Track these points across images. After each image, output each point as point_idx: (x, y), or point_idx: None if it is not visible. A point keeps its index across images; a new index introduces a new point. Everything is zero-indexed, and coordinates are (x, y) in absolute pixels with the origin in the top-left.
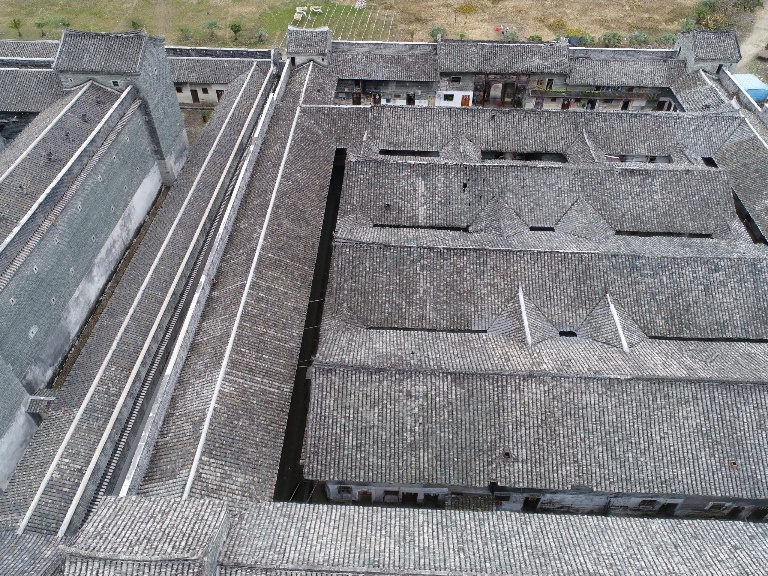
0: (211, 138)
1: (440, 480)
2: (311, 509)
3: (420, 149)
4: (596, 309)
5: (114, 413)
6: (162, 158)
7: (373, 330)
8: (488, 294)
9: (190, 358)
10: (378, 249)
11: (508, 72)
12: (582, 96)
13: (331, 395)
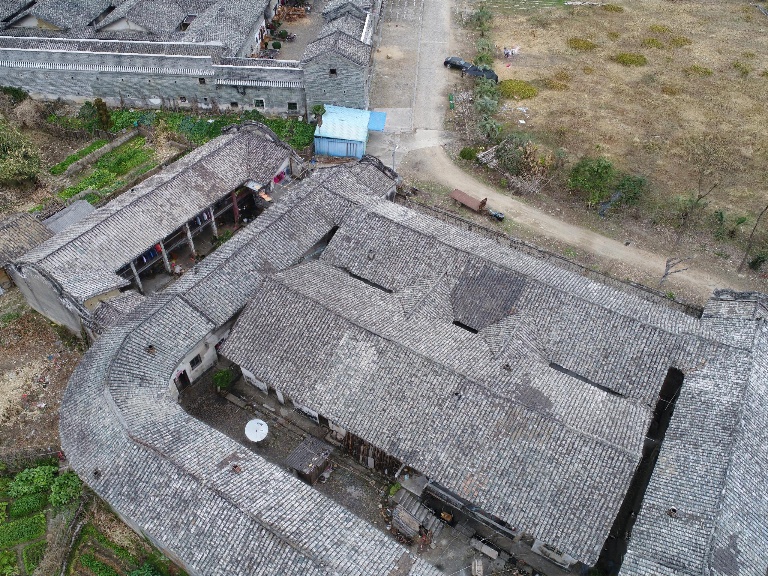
0: None
1: None
2: None
3: None
4: None
5: None
6: None
7: None
8: None
9: None
10: None
11: None
12: None
13: None
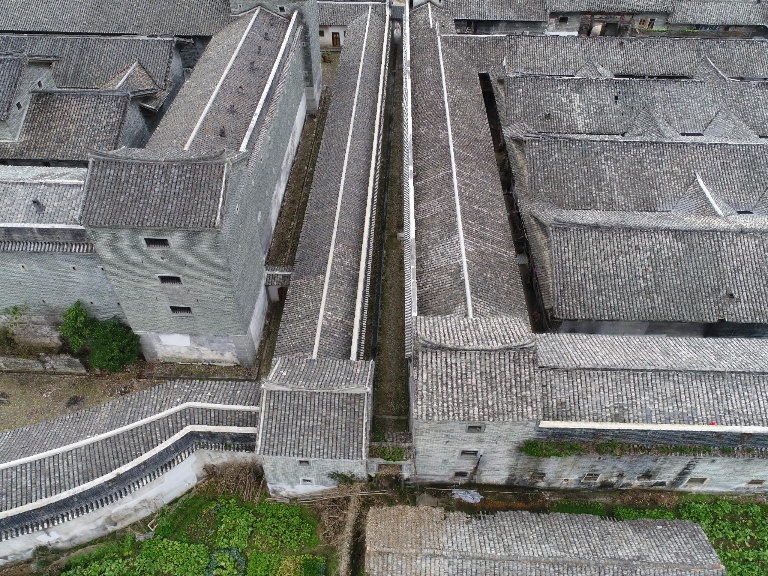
0: (352, 68)
1: (675, 317)
2: (574, 337)
3: (556, 73)
4: (767, 191)
5: (361, 276)
6: (311, 85)
7: (572, 210)
8: (668, 180)
9: (418, 231)
10: (565, 143)
11: (615, 11)
12: (681, 35)
13: (569, 249)
